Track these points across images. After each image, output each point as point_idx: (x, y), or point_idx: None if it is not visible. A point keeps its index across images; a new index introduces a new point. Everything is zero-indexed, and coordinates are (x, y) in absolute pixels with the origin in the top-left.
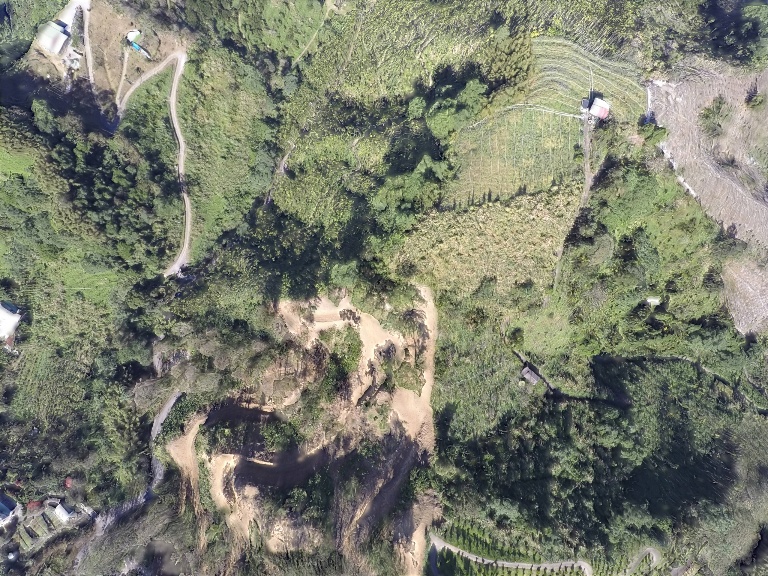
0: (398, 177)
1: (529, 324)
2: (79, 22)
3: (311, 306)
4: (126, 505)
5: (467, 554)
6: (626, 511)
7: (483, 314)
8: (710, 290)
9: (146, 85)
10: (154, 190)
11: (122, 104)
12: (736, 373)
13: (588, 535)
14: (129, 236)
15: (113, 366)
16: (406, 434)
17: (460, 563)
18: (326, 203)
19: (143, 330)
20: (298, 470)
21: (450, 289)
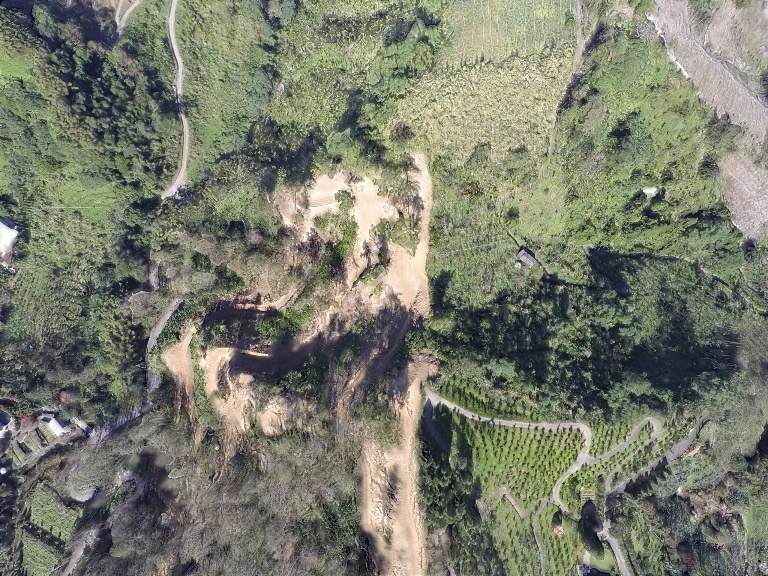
0: (391, 43)
1: (524, 203)
2: None
3: (306, 190)
4: (121, 420)
5: (463, 411)
6: (625, 380)
7: (478, 188)
8: (705, 177)
9: (145, 4)
10: (152, 107)
11: (122, 22)
12: (735, 276)
13: (586, 400)
14: (127, 148)
15: (109, 282)
16: (401, 304)
17: (456, 419)
18: (322, 105)
19: (140, 249)
20: (293, 359)
21: (444, 155)
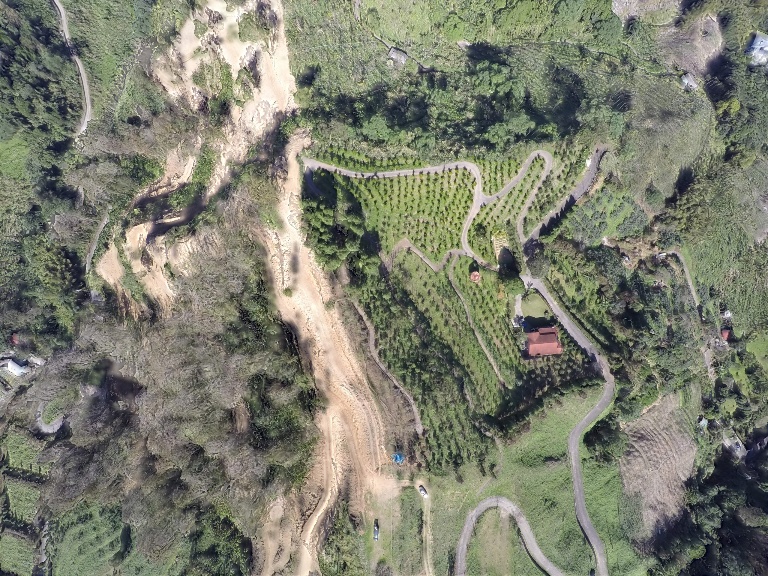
0: None
1: None
2: None
3: (174, 46)
4: (75, 347)
5: (345, 172)
6: (505, 122)
7: None
8: None
9: None
10: None
11: None
12: (622, 50)
13: (469, 145)
14: (22, 88)
15: (39, 223)
16: (276, 110)
17: (338, 178)
18: None
19: (63, 189)
20: None
21: None
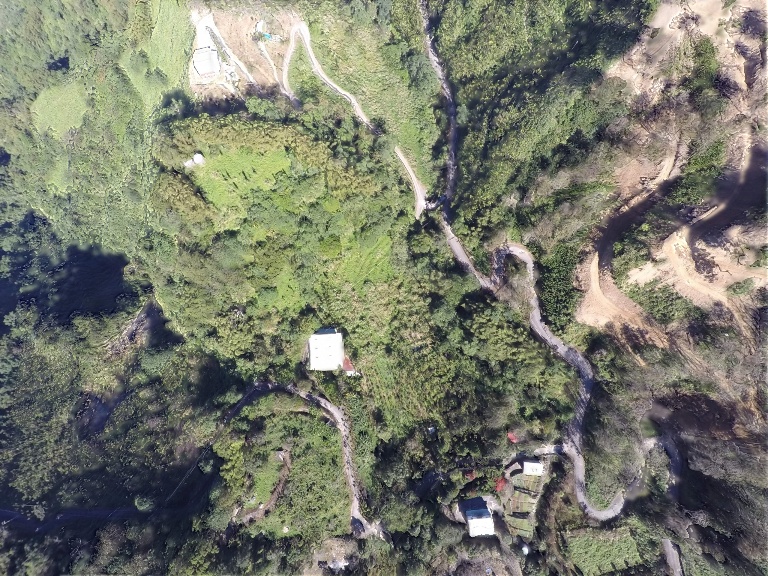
0: None
1: None
2: (215, 39)
3: (642, 42)
4: (578, 414)
5: None
6: None
7: None
8: None
9: (292, 65)
10: None
11: (288, 90)
12: None
13: None
14: (389, 178)
15: (454, 311)
16: None
17: None
18: (540, 7)
19: (445, 268)
20: (744, 190)
21: None
